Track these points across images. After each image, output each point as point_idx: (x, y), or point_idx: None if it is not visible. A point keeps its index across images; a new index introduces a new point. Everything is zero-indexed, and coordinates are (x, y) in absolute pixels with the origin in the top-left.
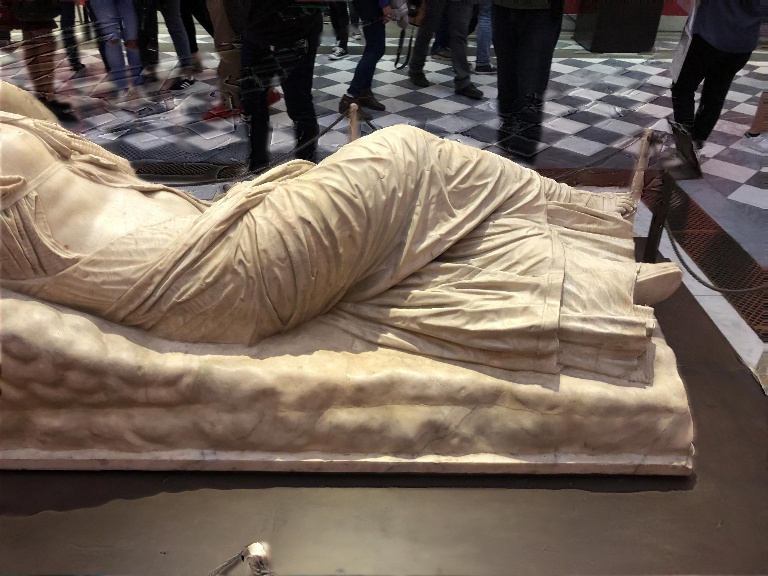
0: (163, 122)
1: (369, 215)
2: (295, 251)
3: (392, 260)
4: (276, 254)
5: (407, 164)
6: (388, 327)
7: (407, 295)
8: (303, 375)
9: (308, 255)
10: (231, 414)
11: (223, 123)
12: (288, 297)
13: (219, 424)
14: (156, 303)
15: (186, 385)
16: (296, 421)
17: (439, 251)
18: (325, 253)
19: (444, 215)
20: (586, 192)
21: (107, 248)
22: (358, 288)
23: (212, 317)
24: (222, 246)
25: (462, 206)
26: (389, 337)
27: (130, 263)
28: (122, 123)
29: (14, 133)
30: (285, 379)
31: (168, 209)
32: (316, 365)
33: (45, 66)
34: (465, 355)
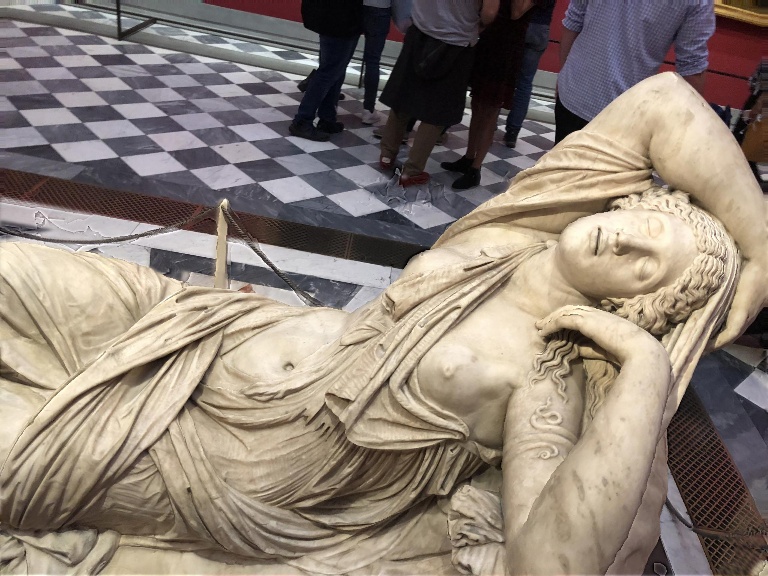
0: None
1: None
2: None
3: None
4: None
5: None
6: None
7: None
8: None
9: None
10: None
11: None
12: None
13: None
14: None
15: None
16: None
17: None
18: None
19: None
20: None
21: None
22: None
23: None
24: None
25: None
26: None
27: None
28: None
29: (426, 253)
30: None
31: (276, 333)
32: None
33: None
34: None
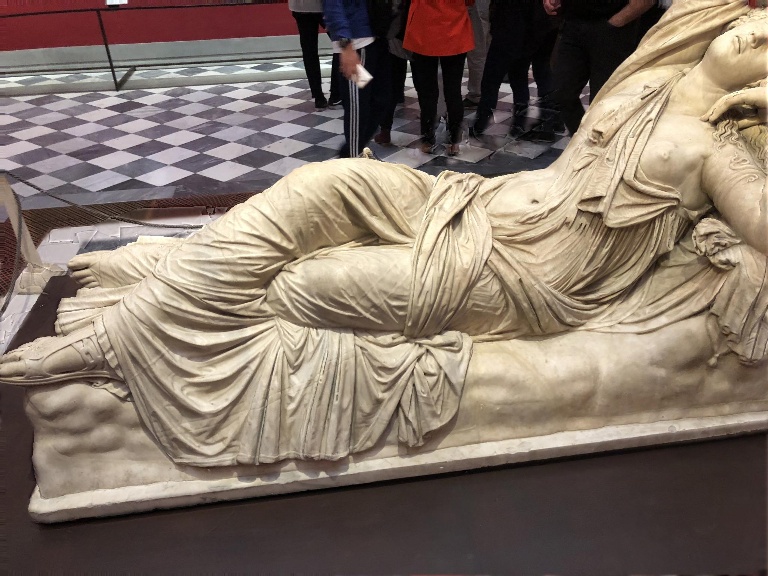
0: None
1: None
2: None
3: None
4: None
5: None
6: None
7: None
8: None
9: None
10: None
11: None
12: None
13: None
14: None
15: None
16: None
17: None
18: None
19: None
20: (73, 335)
21: None
22: None
23: None
24: None
25: None
26: None
27: None
28: None
29: None
30: None
31: None
32: None
33: None
34: None
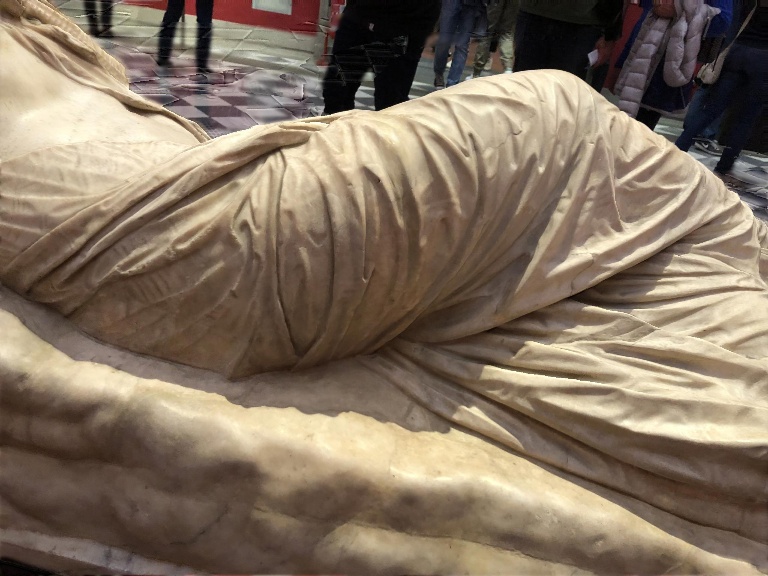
0: (218, 99)
1: (483, 191)
2: (343, 224)
3: (501, 283)
4: (309, 223)
5: (560, 123)
6: (474, 396)
7: (517, 347)
8: (312, 451)
9: (364, 236)
10: (169, 495)
11: (289, 117)
12: (314, 306)
13: (145, 509)
14: (84, 269)
15: (100, 425)
16: (282, 533)
17: (585, 282)
18: (394, 240)
19: (603, 224)
20: None
21: (26, 159)
22: (433, 321)
23: (177, 314)
24: (221, 195)
25: (632, 218)
26: (473, 413)
27: (57, 191)
28: (167, 85)
29: None
30: (278, 451)
31: (154, 130)
32: (339, 437)
33: (94, 5)
34: (609, 474)
